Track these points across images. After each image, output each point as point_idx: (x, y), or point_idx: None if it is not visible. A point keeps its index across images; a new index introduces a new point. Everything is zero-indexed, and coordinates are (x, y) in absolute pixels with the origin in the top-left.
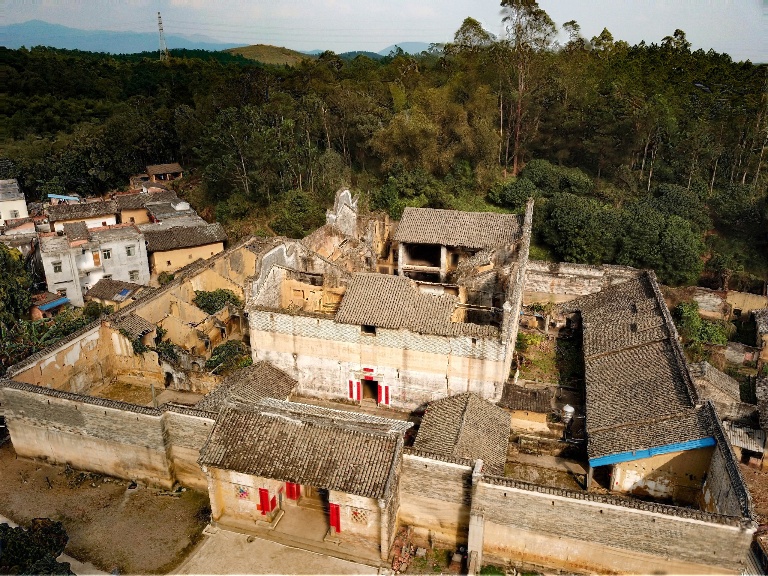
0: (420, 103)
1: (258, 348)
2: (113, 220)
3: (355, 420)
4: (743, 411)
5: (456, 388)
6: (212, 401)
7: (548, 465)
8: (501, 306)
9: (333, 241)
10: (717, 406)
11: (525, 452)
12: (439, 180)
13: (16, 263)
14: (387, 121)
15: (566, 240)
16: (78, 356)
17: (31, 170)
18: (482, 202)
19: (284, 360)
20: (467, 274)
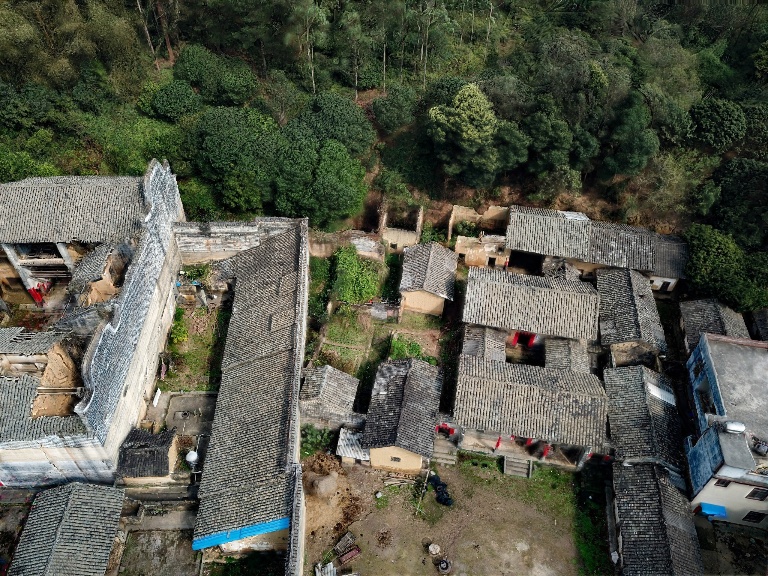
0: None
1: None
2: None
3: None
4: (355, 419)
5: (66, 468)
6: None
7: (171, 527)
8: None
9: None
10: (335, 416)
11: (150, 515)
12: (72, 87)
13: None
14: None
15: (223, 177)
16: None
17: None
18: (133, 113)
19: None
20: None
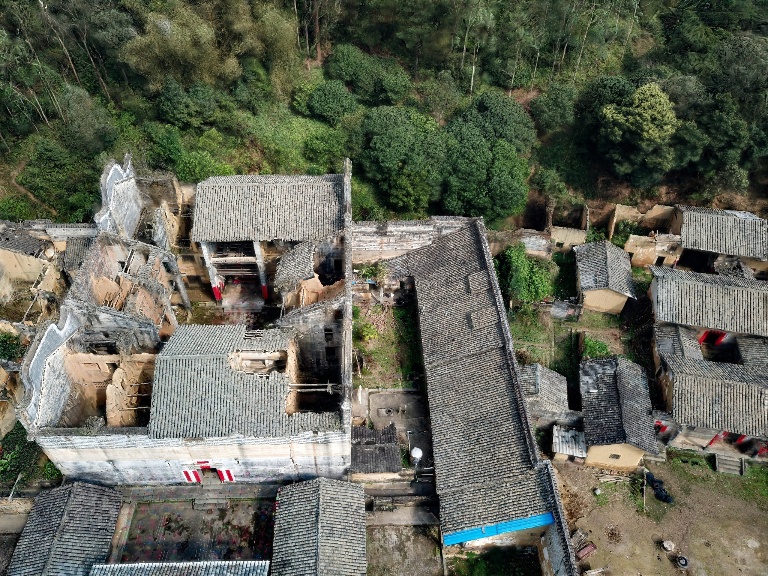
0: None
1: (61, 461)
2: None
3: None
4: (570, 417)
5: (303, 463)
6: (26, 574)
7: (404, 522)
8: (334, 334)
9: (115, 250)
10: (548, 413)
11: (381, 510)
12: (229, 87)
13: None
14: (141, 25)
15: (390, 176)
16: None
17: None
18: (287, 113)
19: (99, 466)
20: (290, 288)
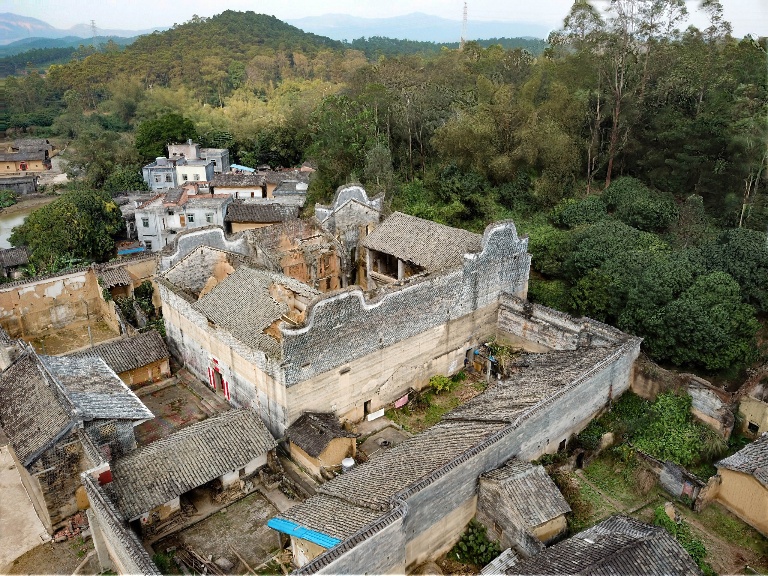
0: (502, 100)
1: (166, 317)
2: (260, 192)
3: (63, 392)
4: (530, 545)
5: (262, 402)
6: None
7: None
8: None
9: None
10: (510, 526)
11: (282, 490)
12: None
13: (108, 214)
14: None
15: (581, 279)
16: (61, 292)
17: (243, 143)
18: (542, 220)
19: (177, 333)
20: None
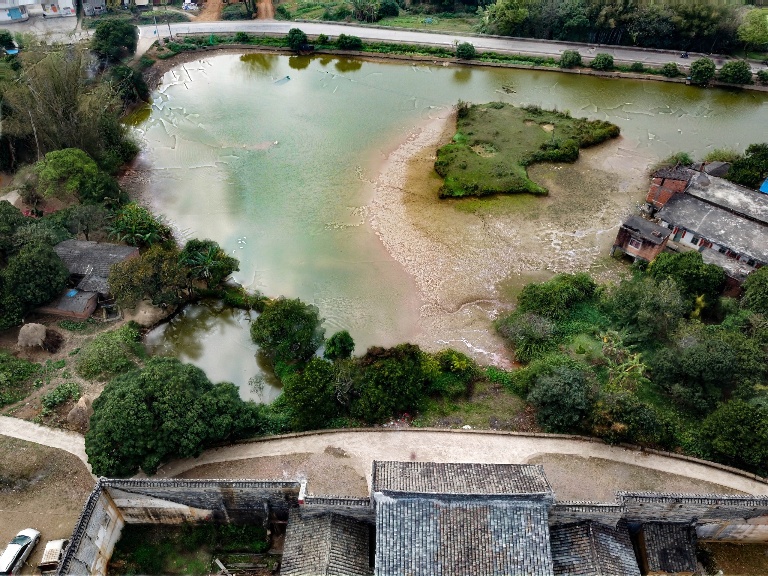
0: None
1: None
2: None
3: (417, 491)
4: None
5: None
6: None
7: None
8: None
9: None
10: None
11: None
12: None
13: None
14: None
15: None
16: None
17: None
18: None
19: None
20: None
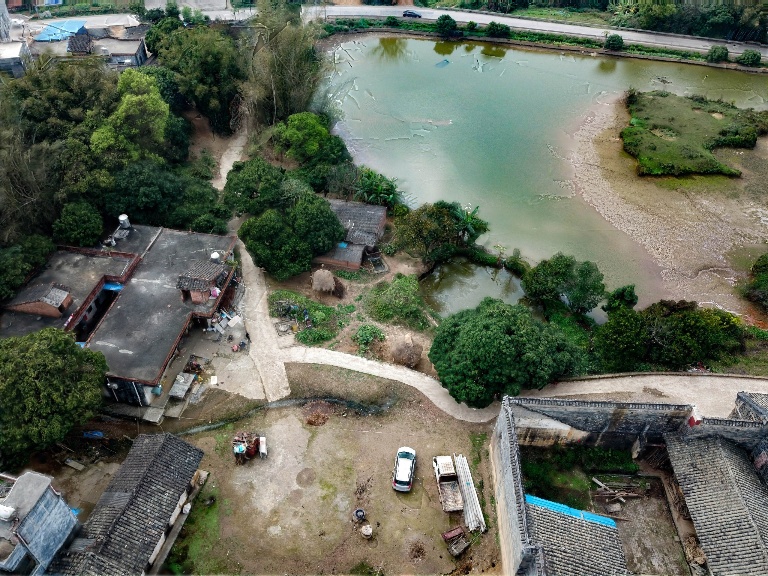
0: None
1: None
2: None
3: None
4: None
5: None
6: None
7: None
8: None
9: None
10: None
11: None
12: None
13: None
14: None
15: None
16: None
17: None
18: None
19: None
20: None
